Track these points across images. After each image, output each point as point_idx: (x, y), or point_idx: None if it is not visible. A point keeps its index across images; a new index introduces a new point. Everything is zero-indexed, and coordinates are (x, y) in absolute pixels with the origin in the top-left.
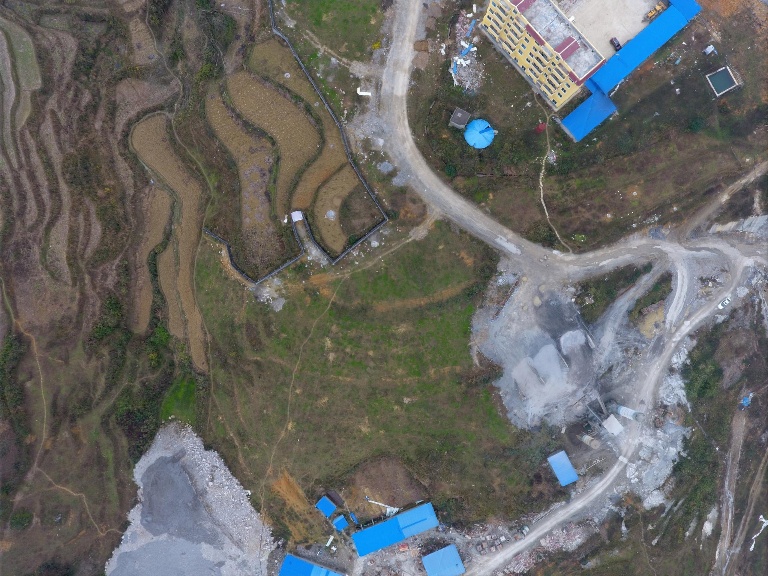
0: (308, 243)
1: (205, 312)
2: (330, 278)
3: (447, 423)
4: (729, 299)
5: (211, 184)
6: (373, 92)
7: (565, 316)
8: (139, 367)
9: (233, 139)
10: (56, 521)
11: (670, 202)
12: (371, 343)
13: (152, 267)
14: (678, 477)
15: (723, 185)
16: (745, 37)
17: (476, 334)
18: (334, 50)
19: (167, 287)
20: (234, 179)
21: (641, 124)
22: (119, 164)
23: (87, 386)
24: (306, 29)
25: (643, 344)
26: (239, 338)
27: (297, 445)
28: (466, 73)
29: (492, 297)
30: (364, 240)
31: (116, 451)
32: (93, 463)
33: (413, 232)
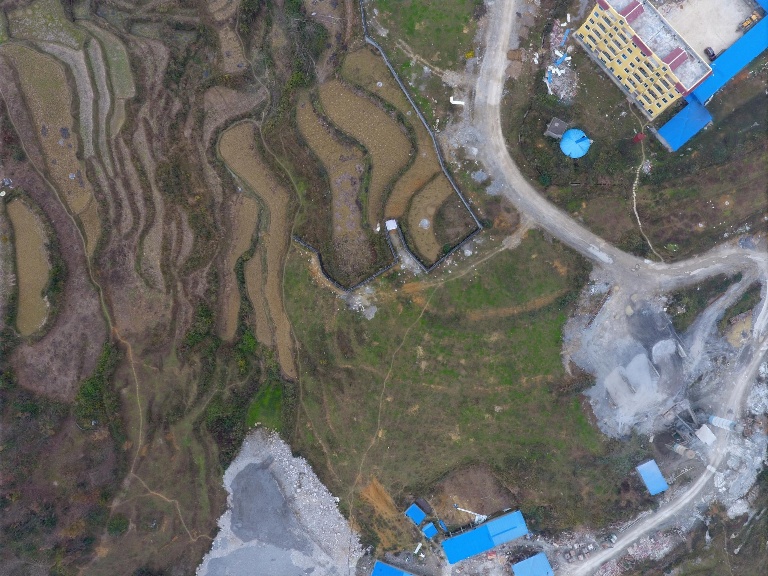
0: (401, 252)
1: (294, 320)
2: (423, 287)
3: (537, 432)
4: None
5: (300, 192)
6: (467, 101)
7: (657, 325)
8: (228, 374)
9: (324, 147)
10: (151, 527)
11: (762, 212)
12: (463, 351)
13: (240, 274)
14: (762, 486)
15: None
16: None
17: (568, 343)
18: (427, 59)
19: (254, 294)
20: (325, 187)
21: (736, 134)
22: (208, 172)
23: (180, 393)
24: (399, 38)
25: (731, 353)
26: (330, 346)
27: (387, 453)
28: (561, 82)
29: (584, 306)
30: (457, 249)
31: (207, 458)
32: (186, 469)
33: (506, 241)
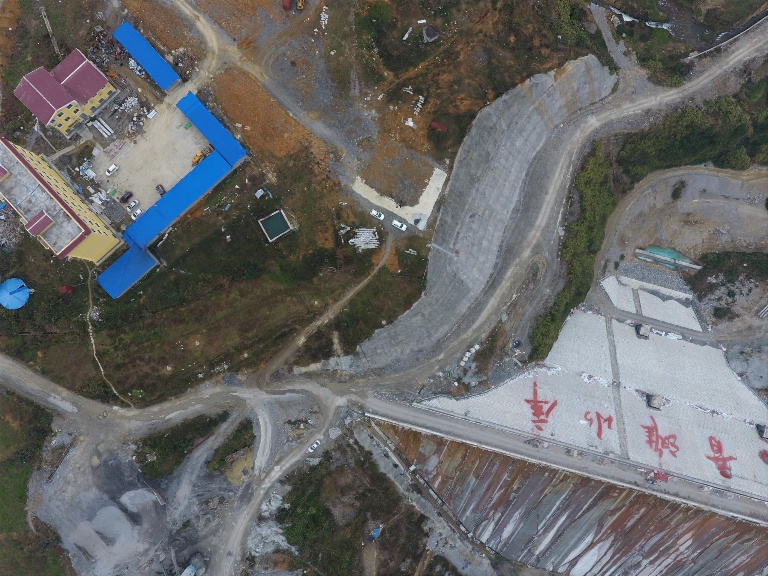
0: None
1: None
2: None
3: None
4: (318, 442)
5: None
6: None
7: (125, 476)
8: None
9: None
10: None
11: (237, 350)
12: None
13: None
14: None
15: (298, 327)
16: (301, 177)
17: (30, 499)
18: None
19: None
20: None
21: (187, 275)
22: None
23: None
24: None
25: (230, 492)
26: None
27: None
28: (3, 228)
29: (46, 459)
30: None
31: None
32: None
33: None
